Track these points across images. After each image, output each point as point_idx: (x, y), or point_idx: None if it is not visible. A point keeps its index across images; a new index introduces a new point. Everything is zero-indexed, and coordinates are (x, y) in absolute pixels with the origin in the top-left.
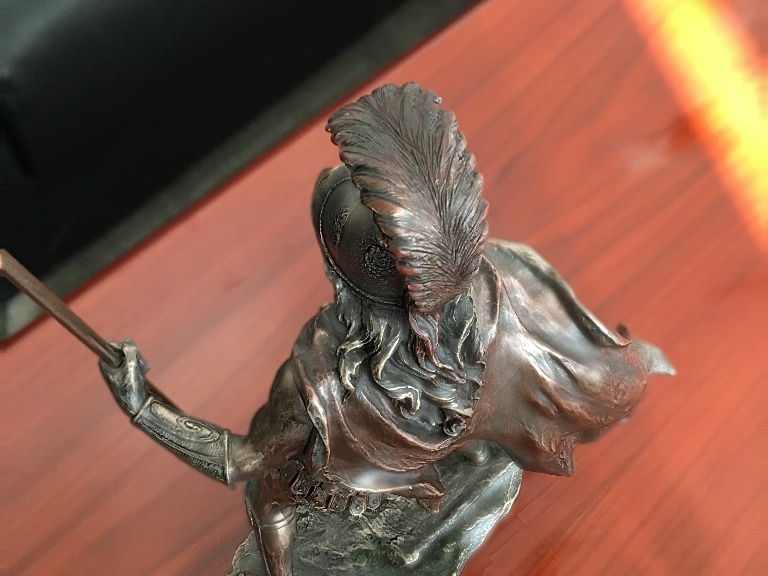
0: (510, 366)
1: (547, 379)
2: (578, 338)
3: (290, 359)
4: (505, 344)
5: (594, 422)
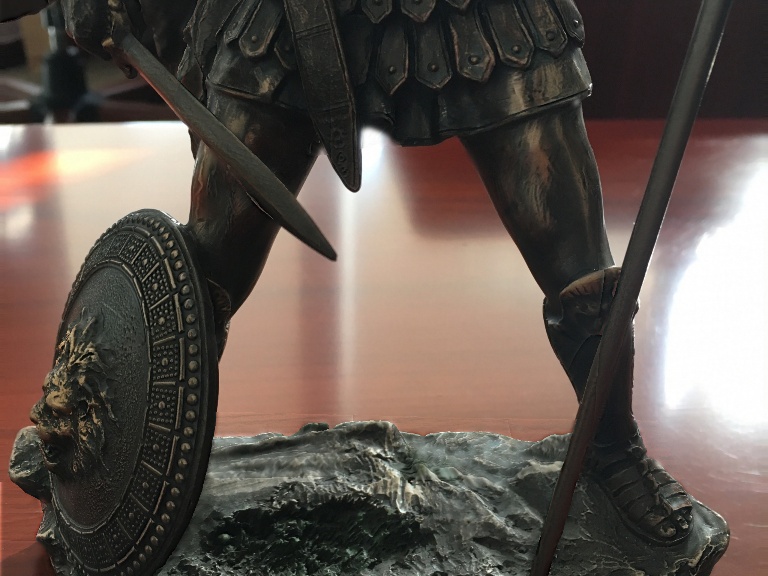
0: None
1: None
2: None
3: None
4: None
5: None
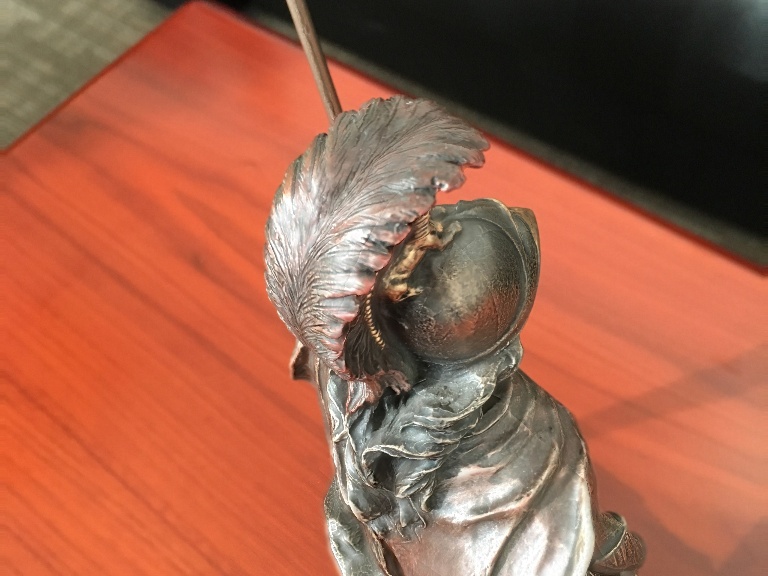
0: (449, 568)
1: None
2: None
3: None
4: (461, 547)
5: None
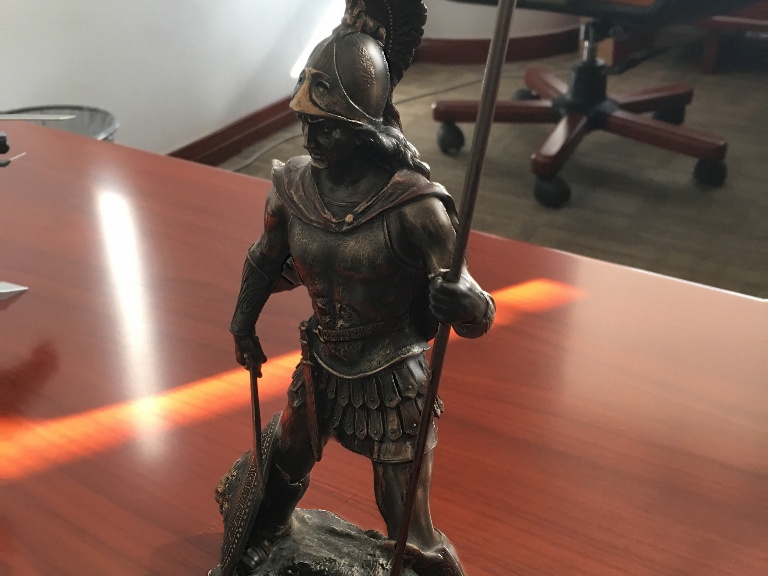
0: None
1: None
2: None
3: (418, 194)
4: None
5: None
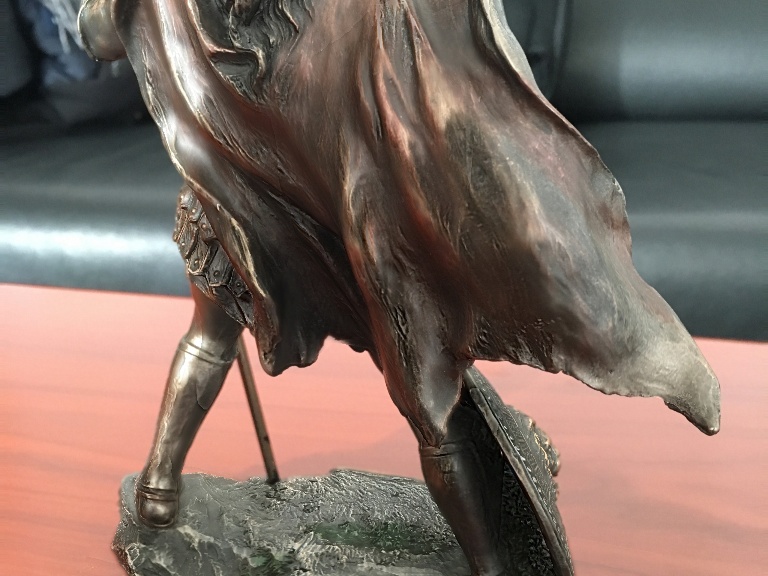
0: (354, 8)
1: (382, 50)
2: (462, 26)
3: None
4: None
5: (432, 217)
